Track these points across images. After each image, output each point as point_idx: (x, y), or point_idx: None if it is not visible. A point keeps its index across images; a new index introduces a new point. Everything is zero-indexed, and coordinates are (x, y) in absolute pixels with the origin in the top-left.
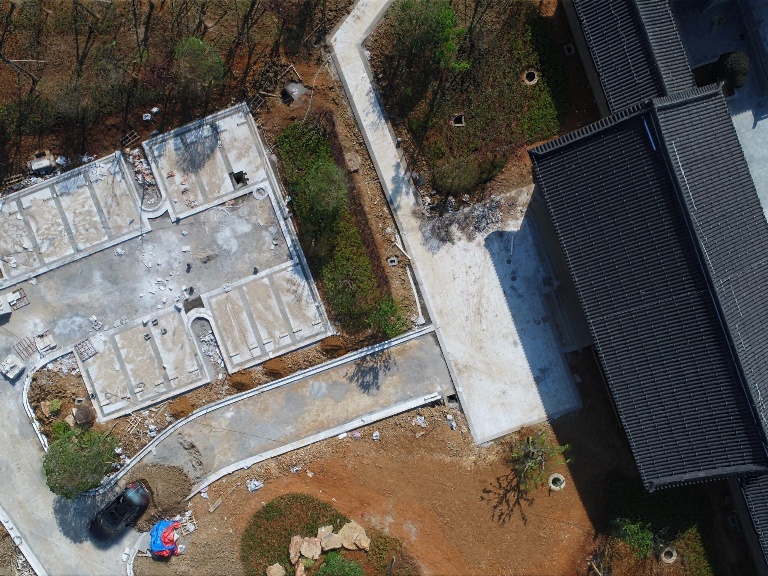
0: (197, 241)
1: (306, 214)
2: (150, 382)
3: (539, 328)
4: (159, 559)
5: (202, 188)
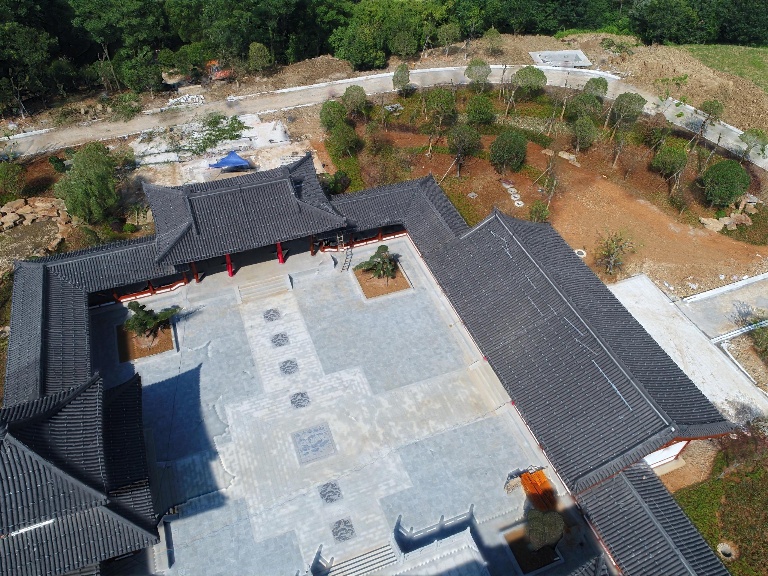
0: None
1: None
2: None
3: None
4: None
5: None
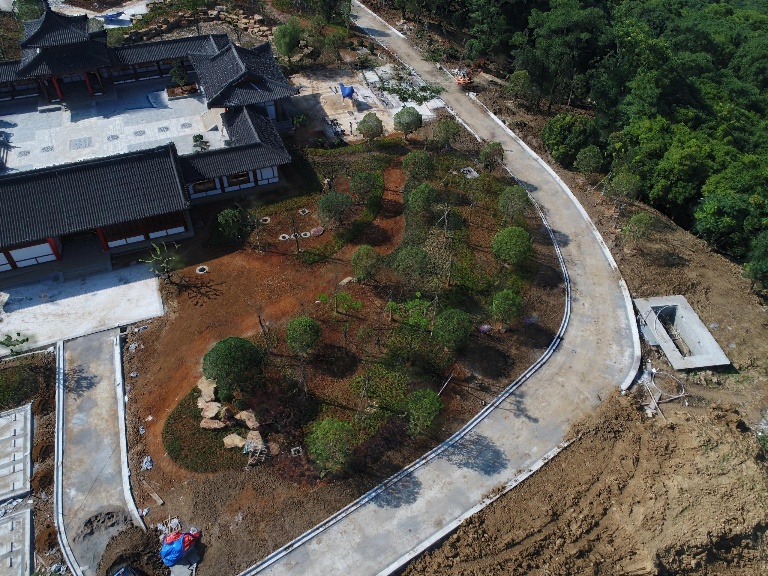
0: None
1: None
2: (5, 573)
3: (88, 283)
4: (201, 556)
5: None
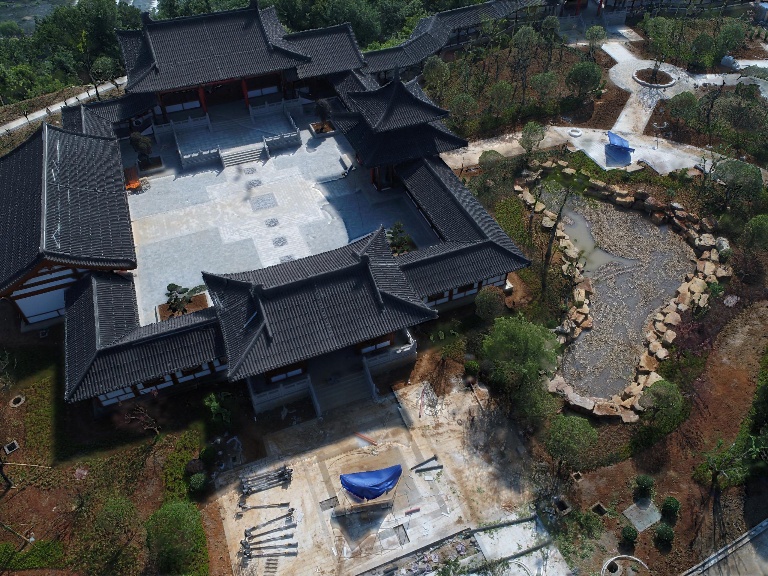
0: None
1: None
2: None
3: None
4: None
5: None
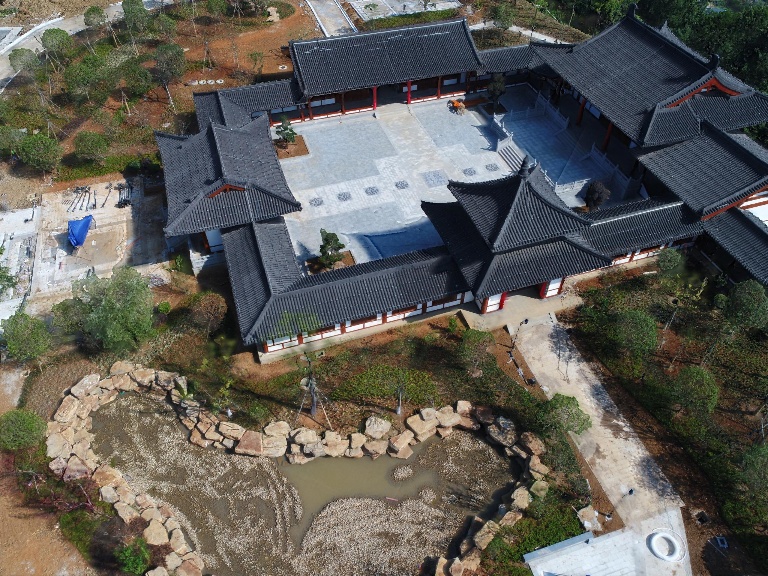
0: None
1: None
2: None
3: None
4: None
5: None
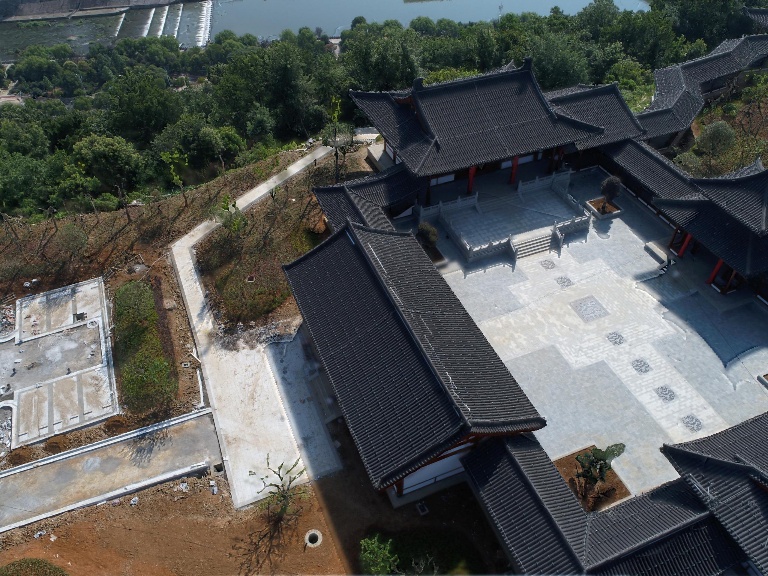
0: (29, 356)
1: (122, 332)
2: None
3: (304, 406)
4: None
5: (49, 323)
